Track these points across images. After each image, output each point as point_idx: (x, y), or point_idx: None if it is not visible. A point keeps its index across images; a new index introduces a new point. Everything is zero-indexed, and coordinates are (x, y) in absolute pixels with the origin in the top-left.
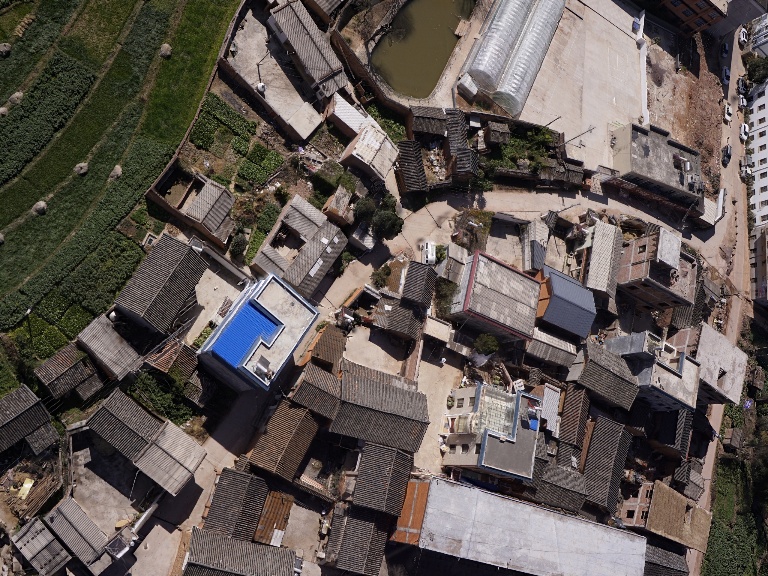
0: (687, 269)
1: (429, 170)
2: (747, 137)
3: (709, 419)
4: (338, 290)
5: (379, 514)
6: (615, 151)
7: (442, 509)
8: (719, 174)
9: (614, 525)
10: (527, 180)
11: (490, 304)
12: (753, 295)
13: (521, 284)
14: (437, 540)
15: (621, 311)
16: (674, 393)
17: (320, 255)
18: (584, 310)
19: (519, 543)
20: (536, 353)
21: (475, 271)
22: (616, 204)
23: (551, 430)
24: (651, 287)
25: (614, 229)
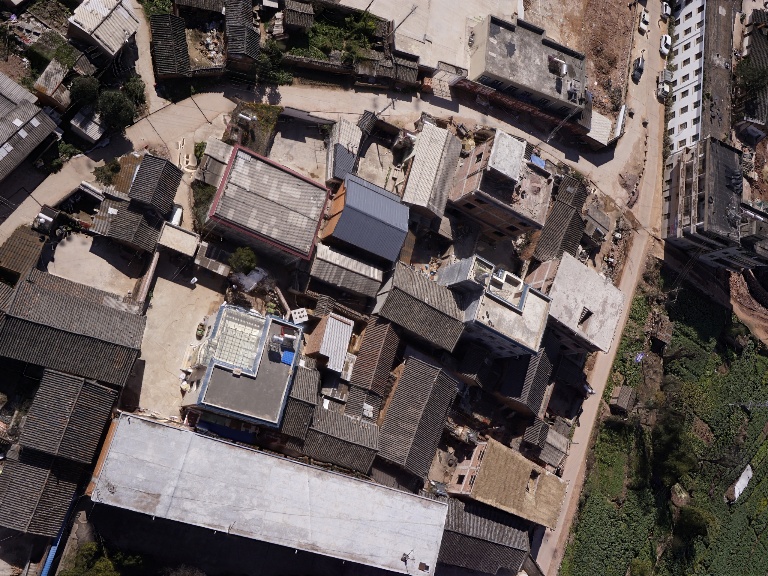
0: (539, 184)
1: (203, 55)
2: (669, 51)
3: (591, 374)
4: (51, 189)
5: (61, 459)
6: (472, 50)
7: (133, 454)
8: (626, 90)
9: (432, 491)
10: (343, 75)
11: (248, 210)
12: (665, 233)
13: (298, 190)
14: (121, 493)
15: (457, 235)
16: (509, 332)
17: (7, 139)
18: (390, 226)
19: (250, 502)
20: (324, 277)
21: (229, 169)
22: (470, 112)
23: (335, 370)
24: (487, 204)
25: (446, 134)
